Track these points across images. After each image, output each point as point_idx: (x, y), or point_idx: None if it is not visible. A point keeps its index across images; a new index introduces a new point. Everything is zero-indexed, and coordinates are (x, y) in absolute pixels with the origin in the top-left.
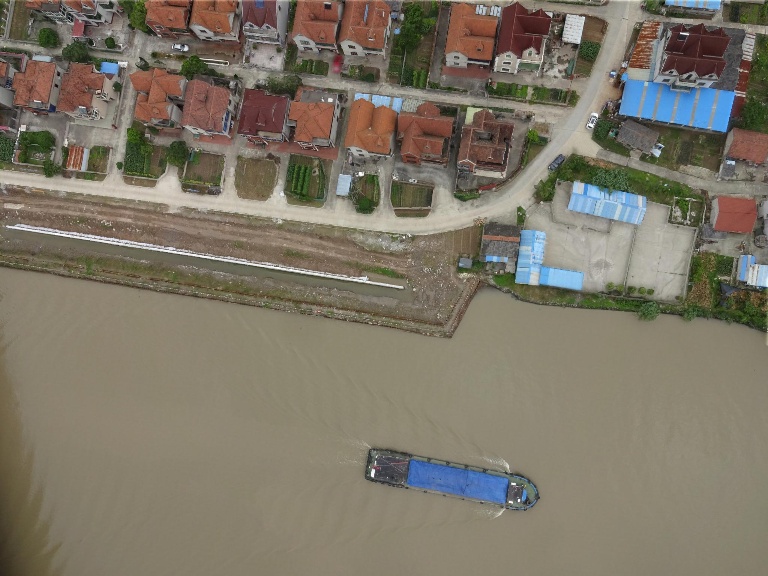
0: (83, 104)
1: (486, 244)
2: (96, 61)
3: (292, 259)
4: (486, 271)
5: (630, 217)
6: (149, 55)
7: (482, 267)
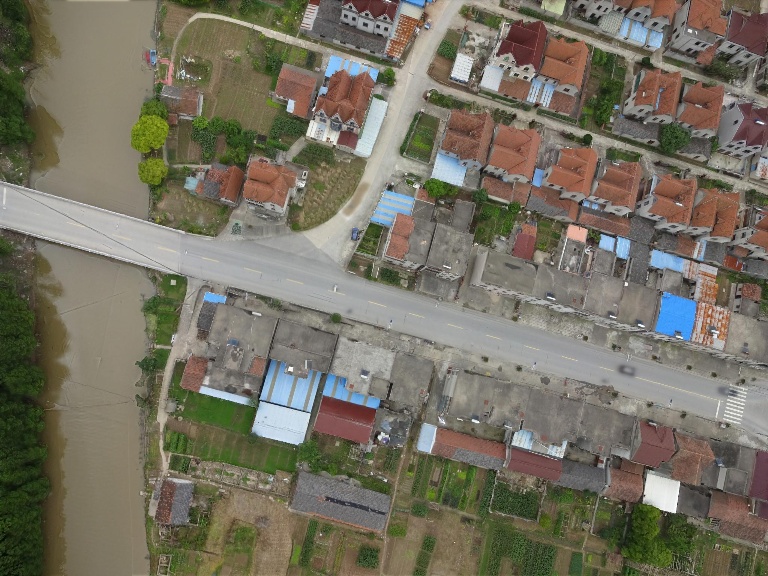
0: None
1: None
2: None
3: None
4: None
5: None
6: None
7: None
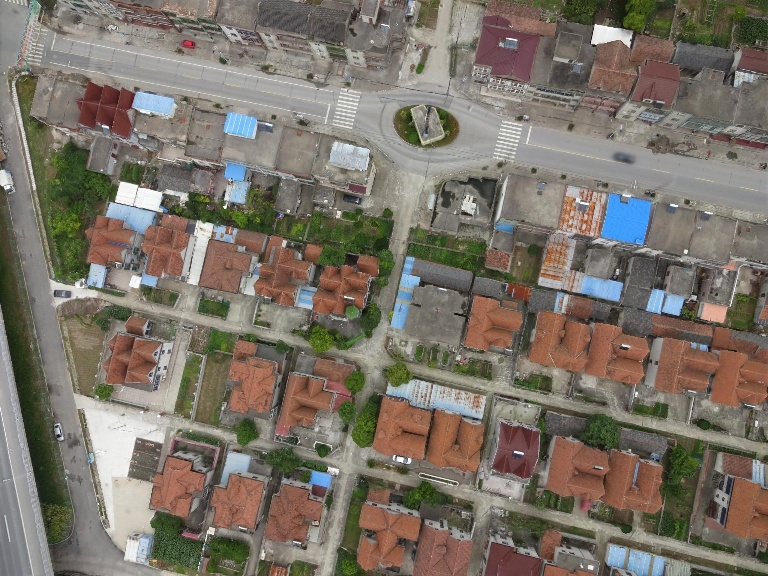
0: (298, 538)
1: None
2: (306, 471)
3: None
4: None
5: None
6: (363, 461)
7: None
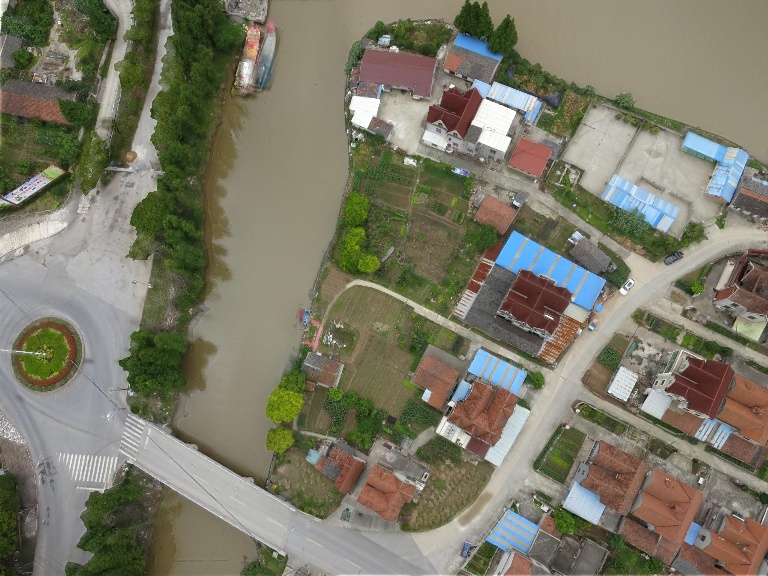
0: None
1: None
2: None
3: None
4: None
5: (623, 183)
6: None
7: None
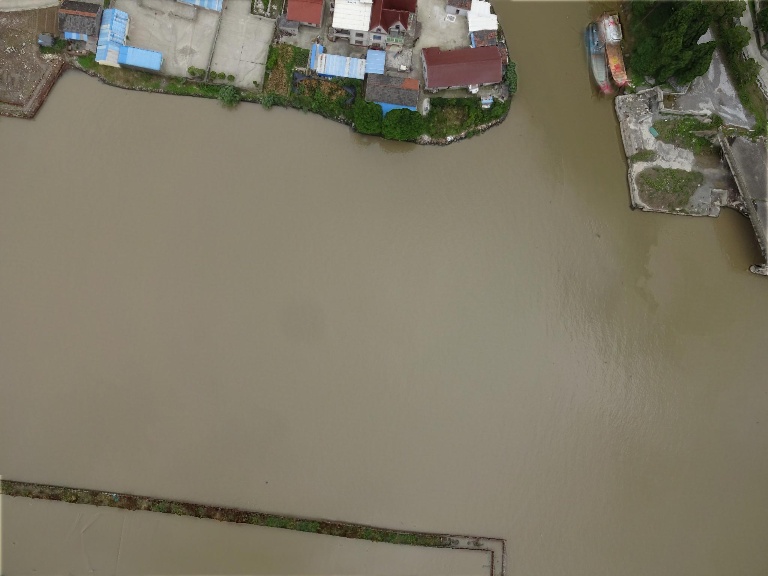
0: None
1: (62, 18)
2: None
3: None
4: (68, 51)
5: (210, 2)
6: None
7: (64, 46)
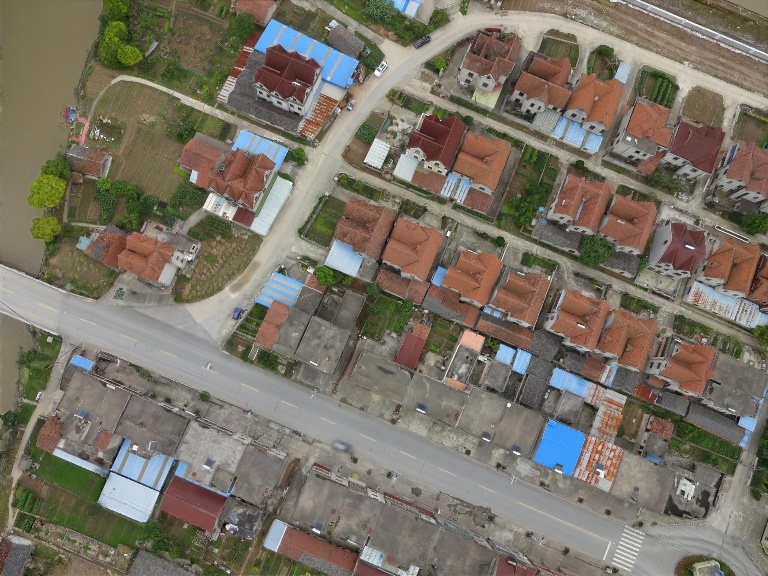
0: None
1: None
2: None
3: (677, 34)
4: None
5: None
6: None
7: None
